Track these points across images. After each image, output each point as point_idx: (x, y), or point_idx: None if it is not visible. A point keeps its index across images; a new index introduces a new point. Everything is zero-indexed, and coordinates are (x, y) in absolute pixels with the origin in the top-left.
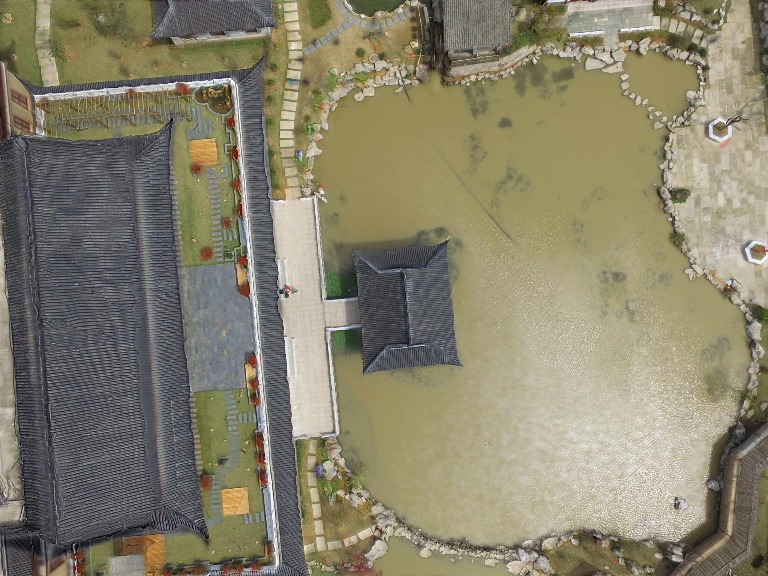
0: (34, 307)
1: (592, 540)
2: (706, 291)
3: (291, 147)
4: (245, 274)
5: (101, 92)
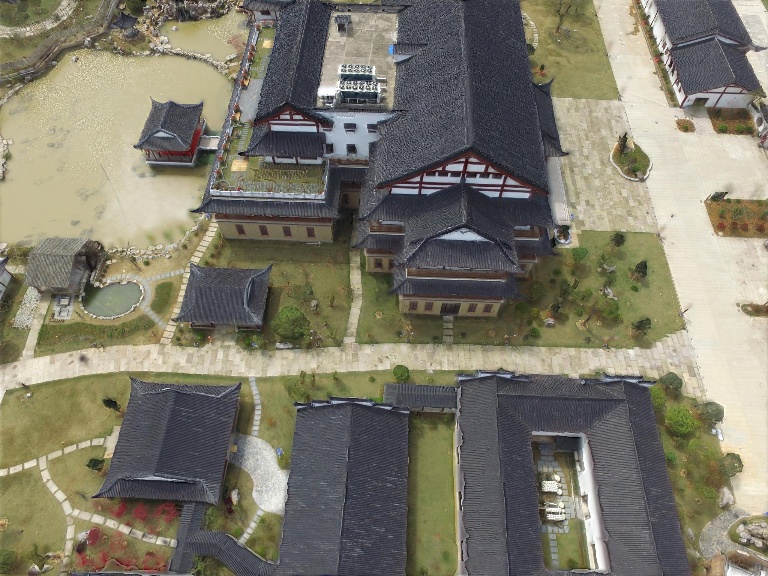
0: (300, 53)
1: (126, 52)
2: (7, 134)
3: (212, 223)
4: (235, 116)
5: (287, 195)
